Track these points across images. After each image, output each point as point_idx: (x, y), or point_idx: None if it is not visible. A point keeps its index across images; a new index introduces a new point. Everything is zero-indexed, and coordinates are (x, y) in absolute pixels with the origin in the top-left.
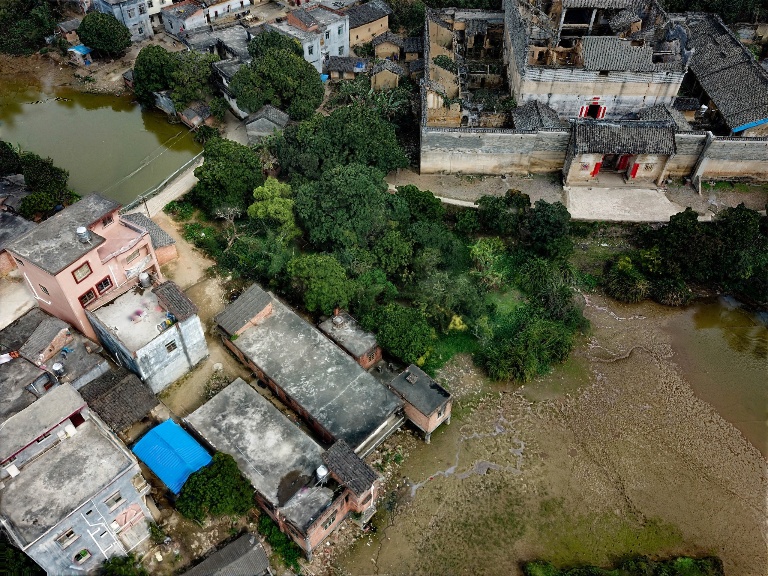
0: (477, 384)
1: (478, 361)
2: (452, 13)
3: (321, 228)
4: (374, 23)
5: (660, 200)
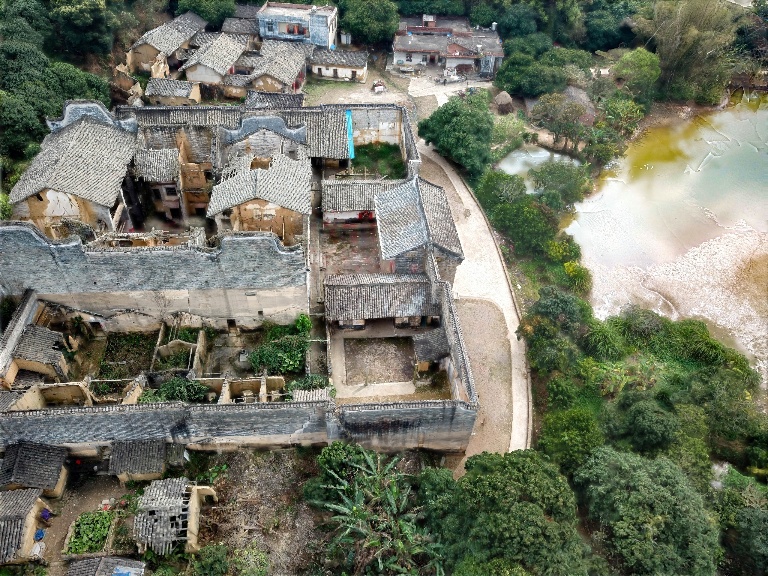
0: None
1: None
2: None
3: (705, 570)
4: None
5: None
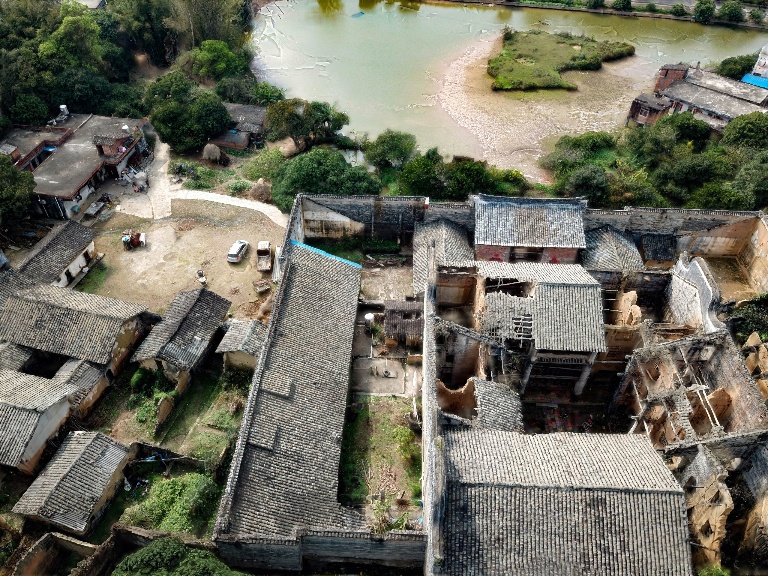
0: None
1: None
2: None
3: None
4: None
5: None
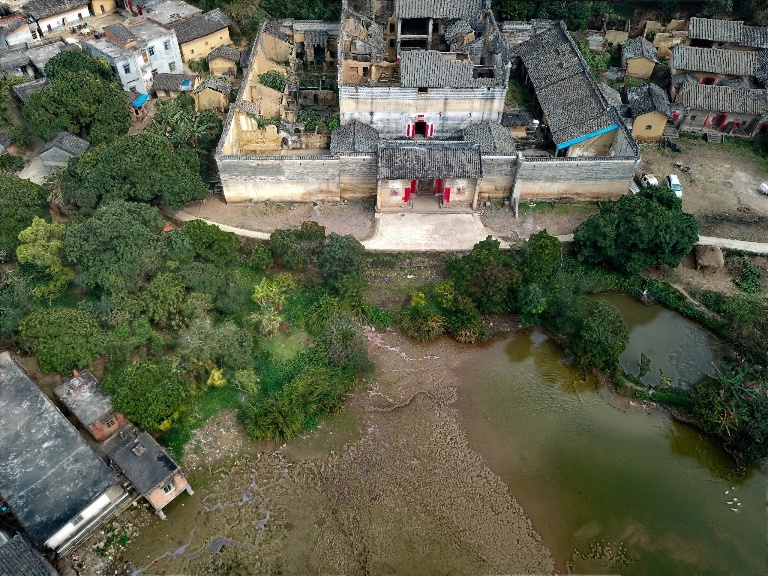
0: (235, 445)
1: (240, 418)
2: (290, 24)
3: (90, 272)
4: (211, 36)
5: (473, 225)
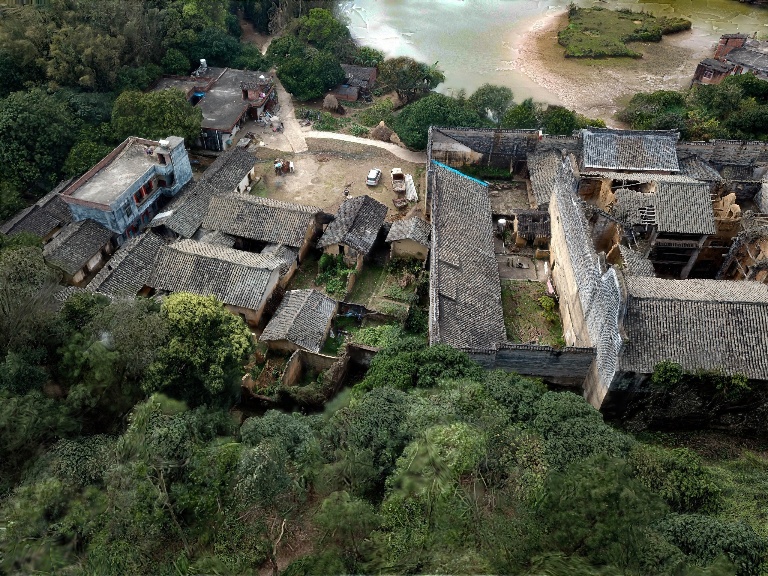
0: None
1: None
2: None
3: None
4: None
5: None
